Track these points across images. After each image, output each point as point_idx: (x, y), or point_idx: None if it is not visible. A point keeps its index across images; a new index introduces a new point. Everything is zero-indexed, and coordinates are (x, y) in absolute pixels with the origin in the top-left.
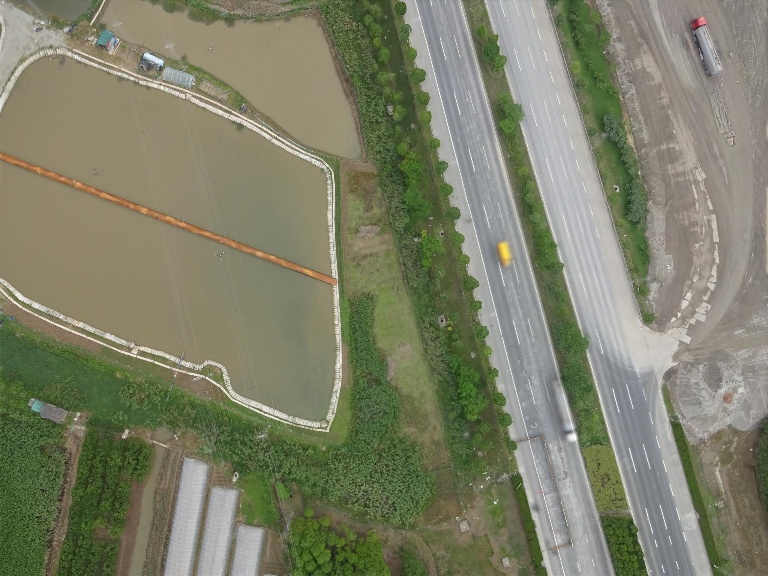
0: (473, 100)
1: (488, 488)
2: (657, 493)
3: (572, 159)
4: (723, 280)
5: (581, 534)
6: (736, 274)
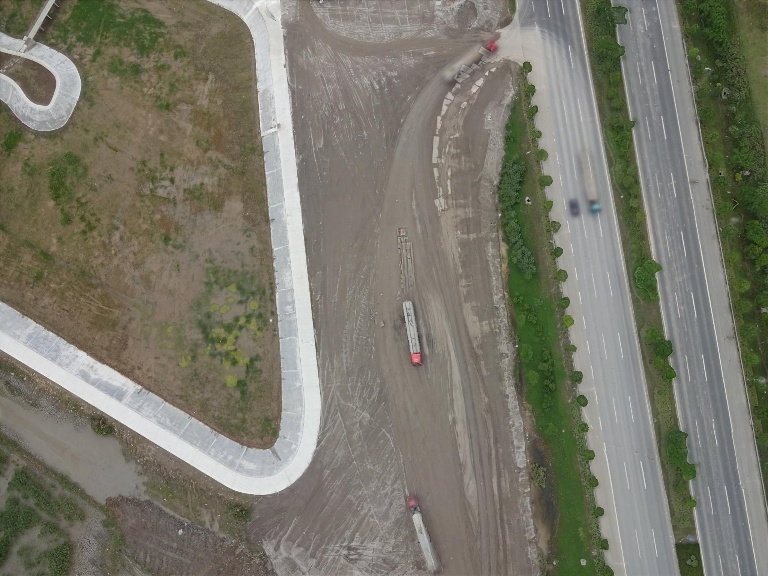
0: (676, 307)
1: None
2: None
3: (574, 233)
4: (437, 101)
5: None
6: (422, 105)
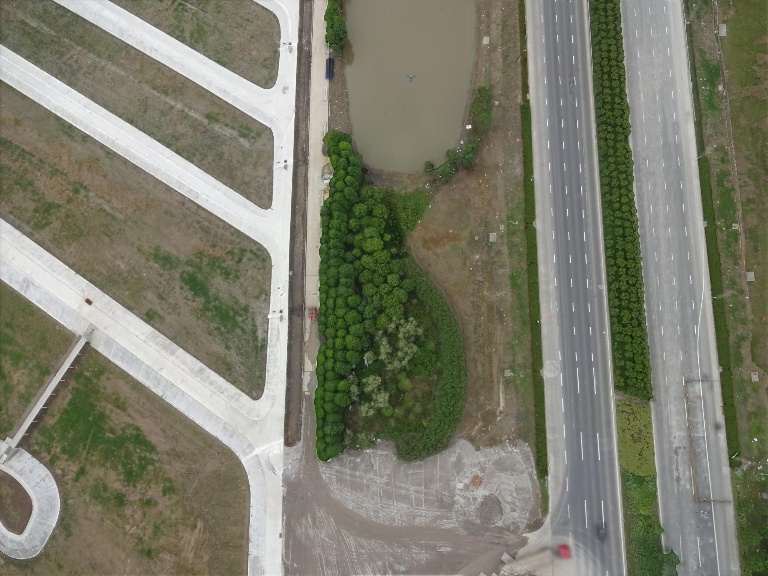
0: None
1: (762, 457)
2: (580, 406)
3: None
4: None
5: (672, 387)
6: None
